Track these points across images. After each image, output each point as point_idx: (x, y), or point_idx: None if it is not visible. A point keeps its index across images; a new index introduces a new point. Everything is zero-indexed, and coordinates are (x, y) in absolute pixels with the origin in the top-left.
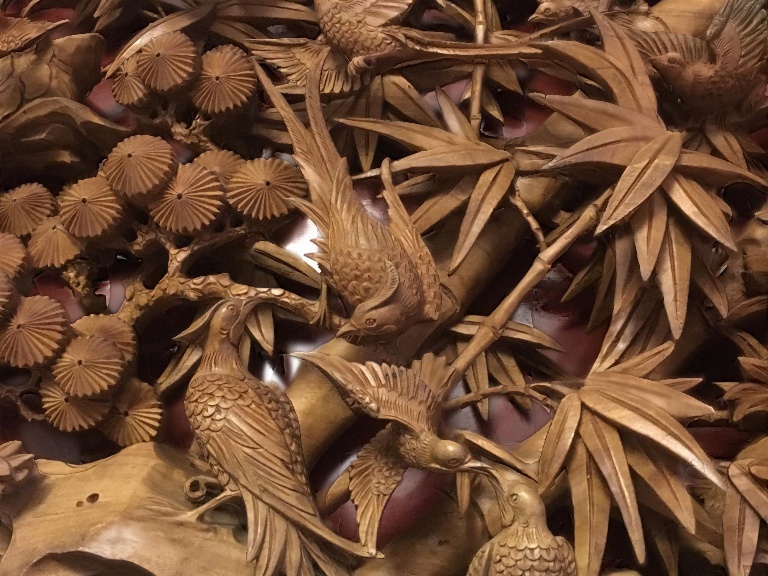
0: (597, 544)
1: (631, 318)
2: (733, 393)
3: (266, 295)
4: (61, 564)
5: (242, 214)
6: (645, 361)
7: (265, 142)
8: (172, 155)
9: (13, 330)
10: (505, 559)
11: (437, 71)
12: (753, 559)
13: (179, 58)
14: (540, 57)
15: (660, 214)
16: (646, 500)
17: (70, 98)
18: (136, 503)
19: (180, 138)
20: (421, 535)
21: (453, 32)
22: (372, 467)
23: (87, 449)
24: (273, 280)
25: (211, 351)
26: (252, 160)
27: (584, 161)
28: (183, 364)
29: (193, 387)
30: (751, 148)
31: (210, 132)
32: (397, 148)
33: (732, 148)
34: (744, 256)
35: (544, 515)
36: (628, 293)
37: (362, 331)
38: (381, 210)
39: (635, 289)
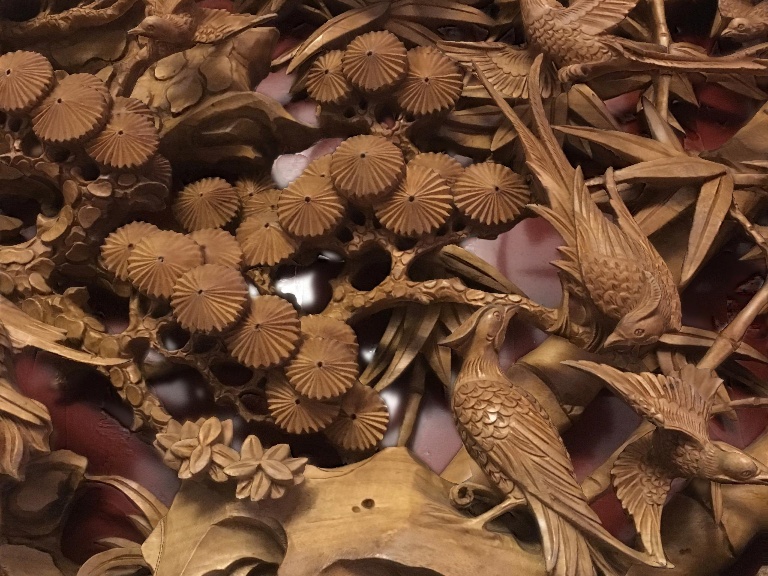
0: None
1: None
2: None
3: (504, 301)
4: (348, 570)
5: (469, 218)
6: None
7: (450, 145)
8: (402, 157)
9: (251, 330)
10: None
11: (616, 80)
12: None
13: (391, 58)
14: (760, 73)
15: None
16: None
17: None
18: (418, 509)
19: None
20: None
21: None
22: (639, 476)
23: (302, 451)
24: (464, 284)
25: (476, 357)
26: None
27: None
28: (395, 367)
29: (465, 393)
30: None
31: (410, 133)
32: (580, 156)
33: None
34: None
35: None
36: None
37: (630, 341)
38: (609, 219)
39: None
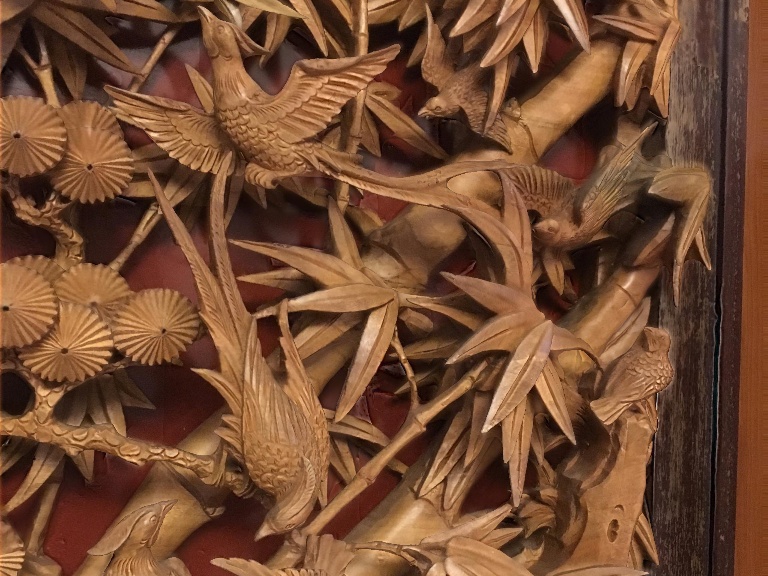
0: None
1: (462, 439)
2: (528, 513)
3: (160, 458)
4: None
5: (130, 359)
6: (489, 523)
7: None
8: (56, 301)
9: None
10: None
11: None
12: None
13: (45, 143)
14: None
15: None
16: None
17: None
18: None
19: (26, 218)
20: None
21: (316, 56)
22: None
23: None
24: None
25: (127, 558)
26: (142, 294)
27: None
28: (33, 482)
29: None
30: (568, 267)
31: (64, 211)
32: (254, 209)
33: (559, 276)
34: None
35: None
36: (478, 448)
37: (280, 532)
38: (277, 359)
39: (483, 443)
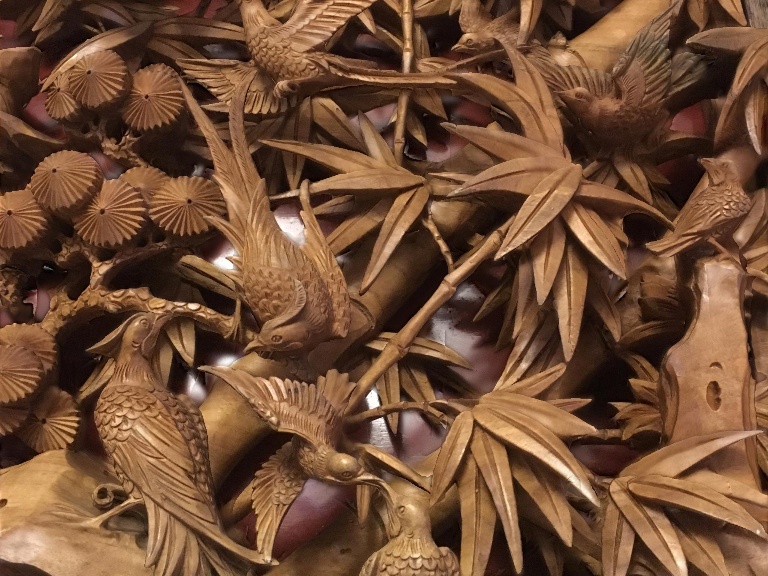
0: (481, 555)
1: (534, 339)
2: (624, 413)
3: (183, 309)
4: None
5: (164, 230)
6: (538, 381)
7: (196, 159)
8: (96, 171)
9: None
10: (390, 568)
11: (365, 95)
12: (627, 571)
13: (109, 76)
14: (455, 87)
15: (558, 242)
16: (527, 514)
17: (5, 110)
18: (42, 509)
19: (110, 153)
20: (324, 544)
21: (384, 57)
22: (274, 478)
23: (6, 455)
24: (198, 293)
25: (123, 363)
26: (176, 178)
27: (489, 189)
28: (104, 374)
29: (103, 398)
30: (657, 179)
31: (139, 148)
32: (324, 168)
33: (638, 179)
34: (641, 283)
35: (429, 527)
36: (528, 316)
37: (269, 347)
38: (298, 230)
39: (535, 312)
